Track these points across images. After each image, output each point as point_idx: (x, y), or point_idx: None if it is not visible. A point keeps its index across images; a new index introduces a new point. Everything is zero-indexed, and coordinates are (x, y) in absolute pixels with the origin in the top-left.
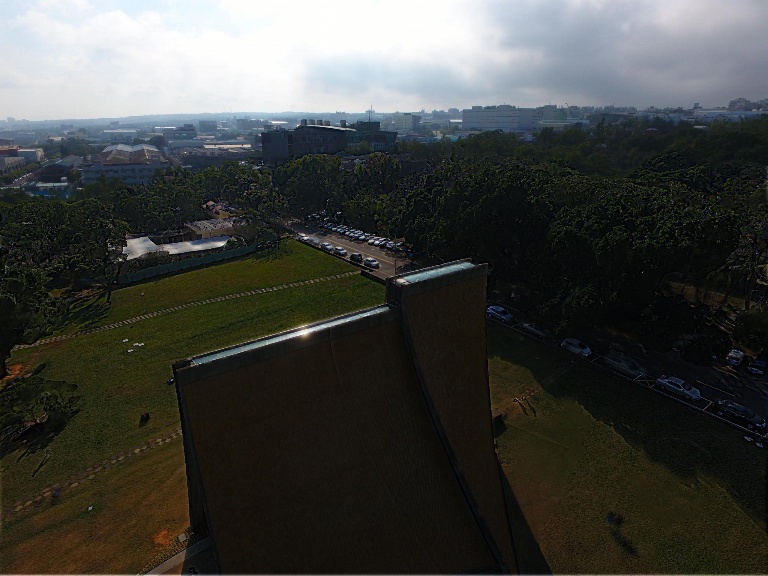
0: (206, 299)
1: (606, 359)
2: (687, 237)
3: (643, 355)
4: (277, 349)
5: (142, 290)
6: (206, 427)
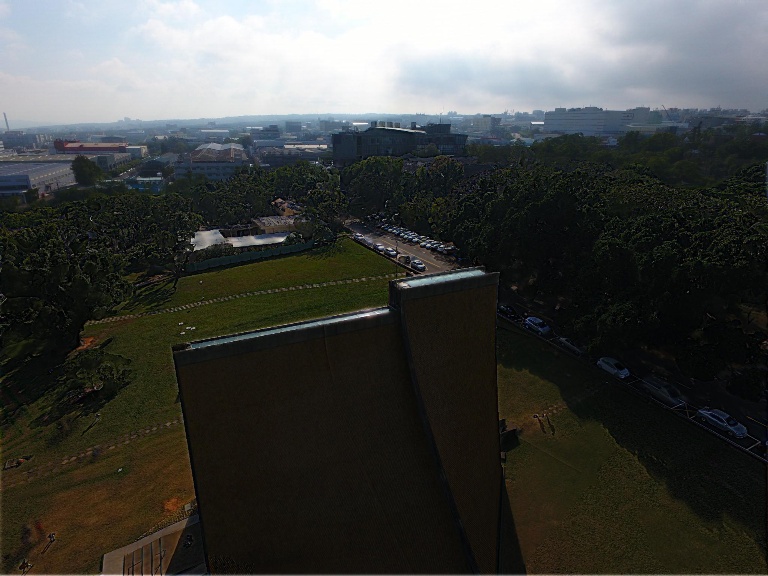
0: (258, 291)
1: (645, 383)
2: (744, 256)
3: (690, 383)
4: (270, 341)
5: (204, 279)
6: (199, 407)
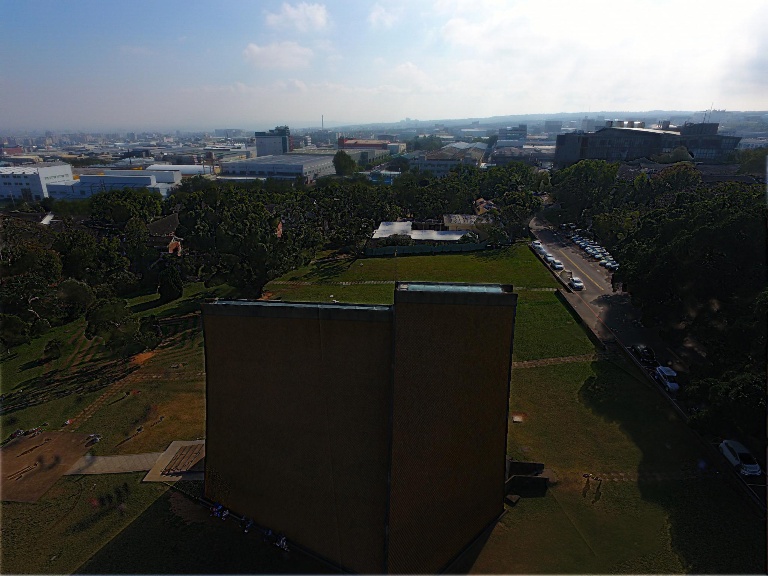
0: None
1: None
2: None
3: None
4: (272, 311)
5: (375, 263)
6: (216, 349)
